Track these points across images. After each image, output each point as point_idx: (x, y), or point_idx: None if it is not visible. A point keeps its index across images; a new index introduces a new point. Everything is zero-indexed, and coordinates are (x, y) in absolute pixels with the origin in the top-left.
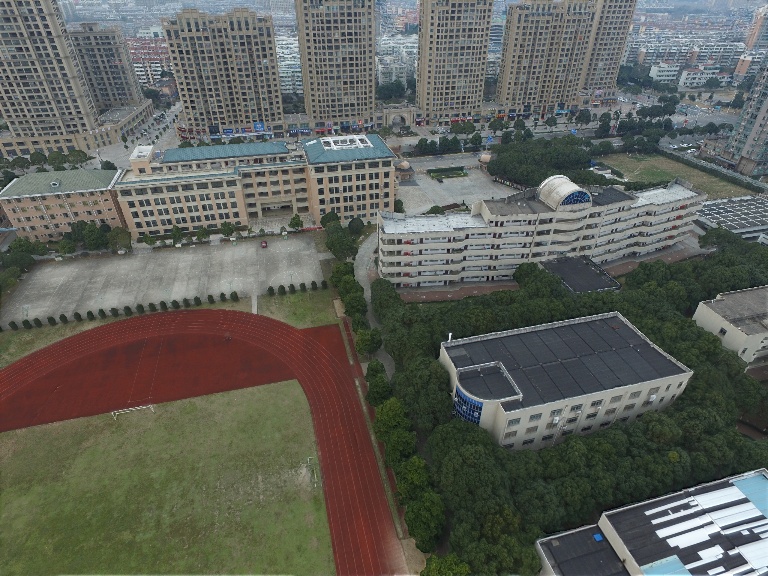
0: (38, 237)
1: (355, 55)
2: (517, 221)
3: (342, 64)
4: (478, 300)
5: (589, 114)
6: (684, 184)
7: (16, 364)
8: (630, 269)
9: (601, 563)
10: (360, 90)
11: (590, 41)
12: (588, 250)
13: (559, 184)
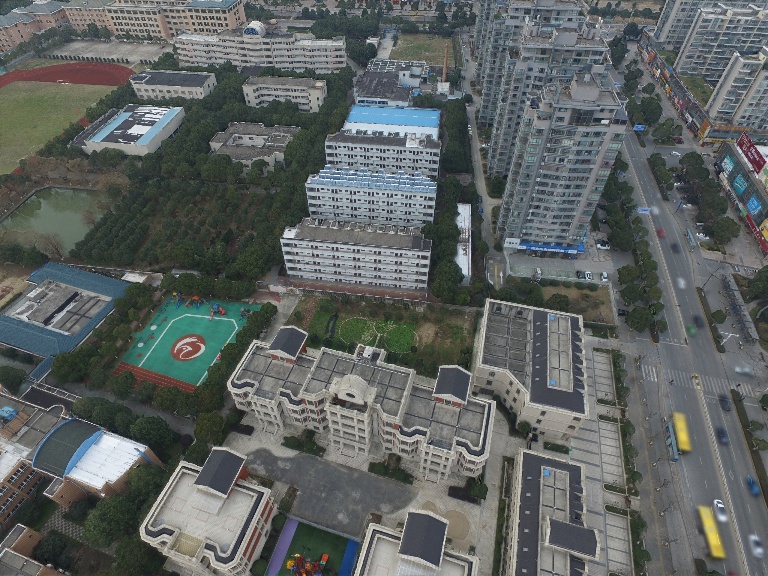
0: (81, 30)
1: None
2: (231, 41)
3: None
4: None
5: (442, 4)
6: None
7: (44, 67)
8: None
9: None
10: None
11: None
12: (272, 64)
13: None
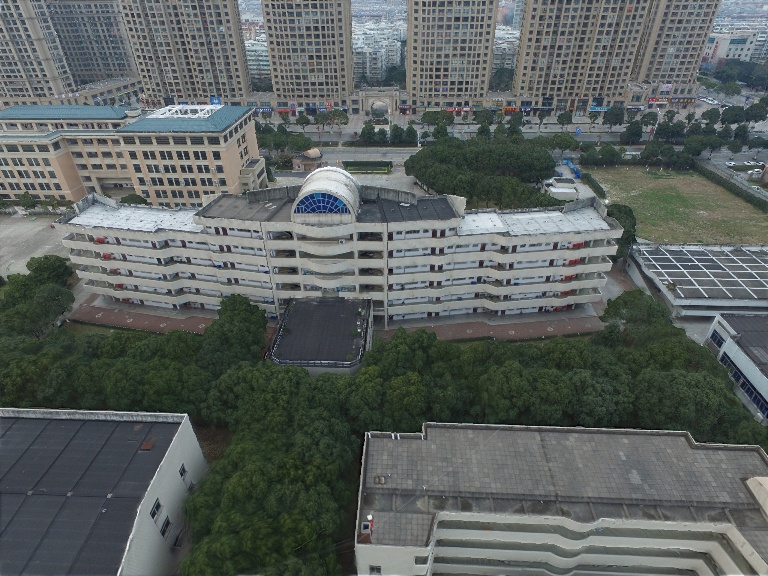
0: None
1: (321, 24)
2: (245, 230)
3: (306, 34)
4: None
5: (621, 111)
6: (599, 208)
7: None
8: (465, 334)
9: None
10: (329, 67)
11: (657, 17)
12: (377, 292)
13: None
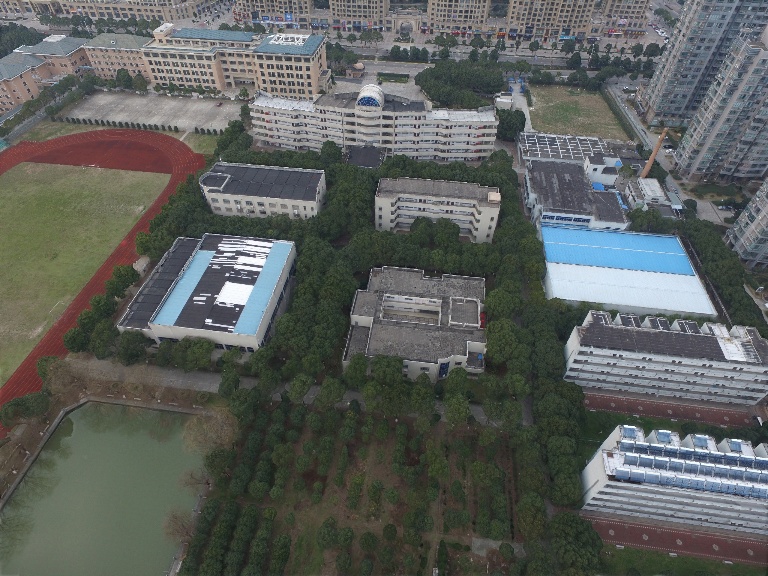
0: (106, 76)
1: None
2: (334, 112)
3: None
4: (272, 152)
5: (572, 43)
6: (494, 111)
7: (60, 138)
8: None
9: (193, 249)
10: None
11: None
12: (390, 144)
13: (364, 90)
